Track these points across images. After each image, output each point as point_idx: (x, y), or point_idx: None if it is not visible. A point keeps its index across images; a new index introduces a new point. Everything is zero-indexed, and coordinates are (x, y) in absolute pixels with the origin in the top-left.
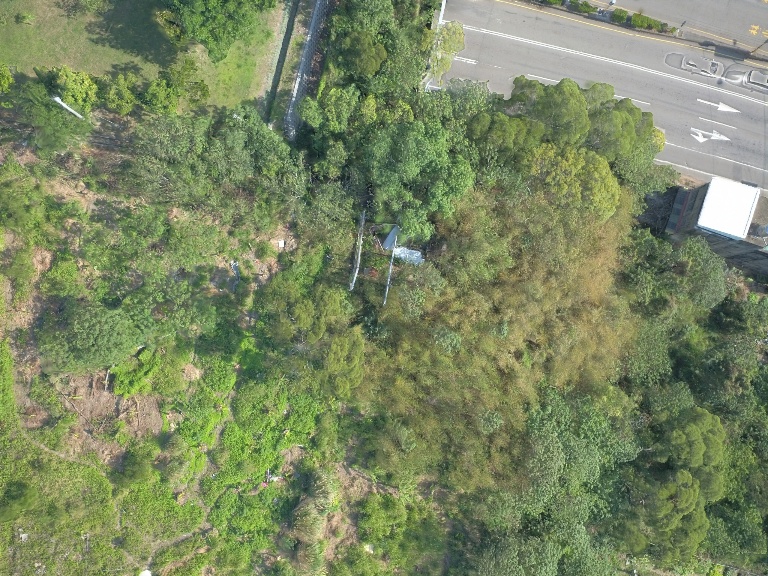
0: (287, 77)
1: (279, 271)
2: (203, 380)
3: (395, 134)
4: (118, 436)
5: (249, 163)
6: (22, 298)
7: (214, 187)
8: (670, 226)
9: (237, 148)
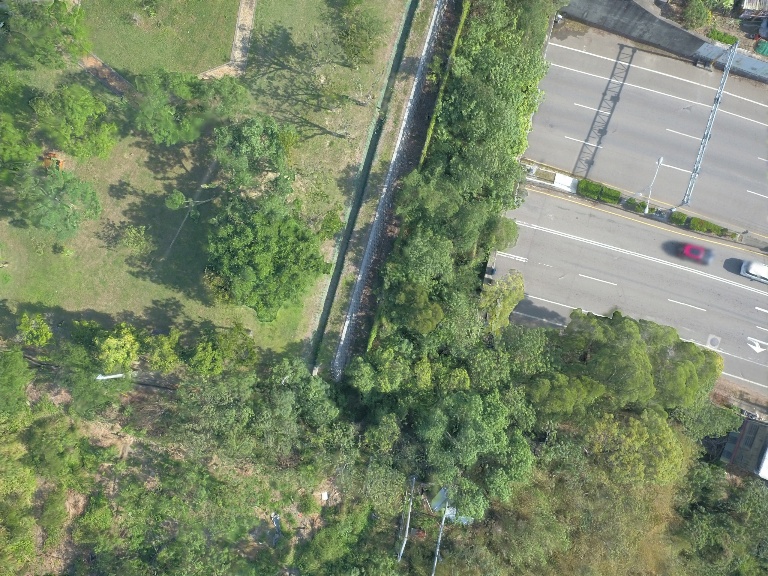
0: (335, 318)
1: (322, 527)
2: None
3: (451, 407)
4: None
5: (296, 432)
6: (53, 543)
7: (257, 443)
8: (725, 455)
9: (284, 416)
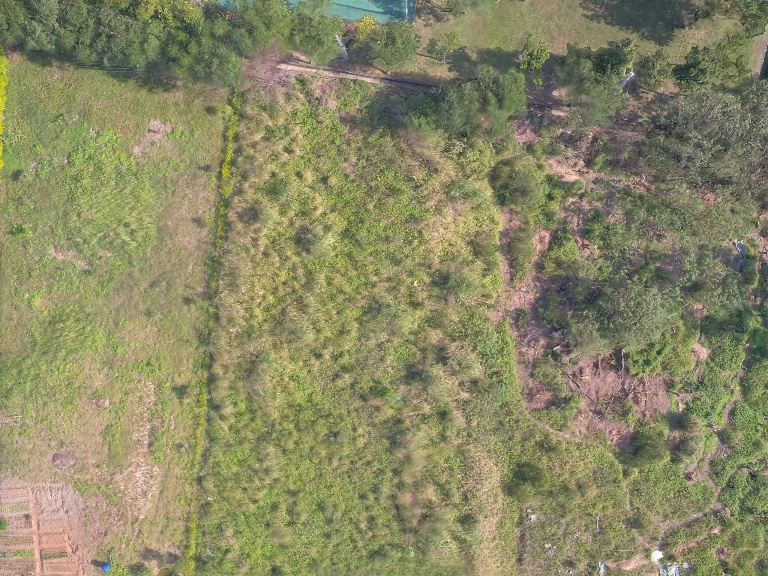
0: None
1: None
2: (711, 359)
3: None
4: (629, 416)
5: None
6: (522, 278)
7: None
8: None
9: None
